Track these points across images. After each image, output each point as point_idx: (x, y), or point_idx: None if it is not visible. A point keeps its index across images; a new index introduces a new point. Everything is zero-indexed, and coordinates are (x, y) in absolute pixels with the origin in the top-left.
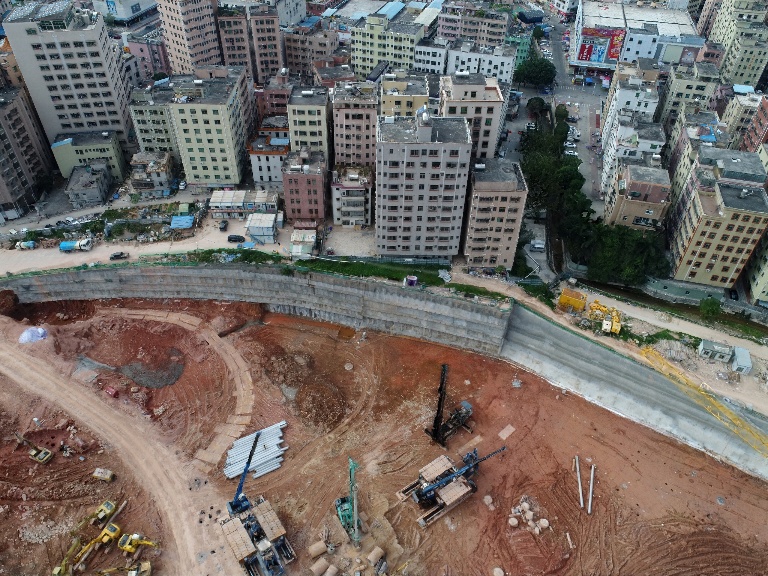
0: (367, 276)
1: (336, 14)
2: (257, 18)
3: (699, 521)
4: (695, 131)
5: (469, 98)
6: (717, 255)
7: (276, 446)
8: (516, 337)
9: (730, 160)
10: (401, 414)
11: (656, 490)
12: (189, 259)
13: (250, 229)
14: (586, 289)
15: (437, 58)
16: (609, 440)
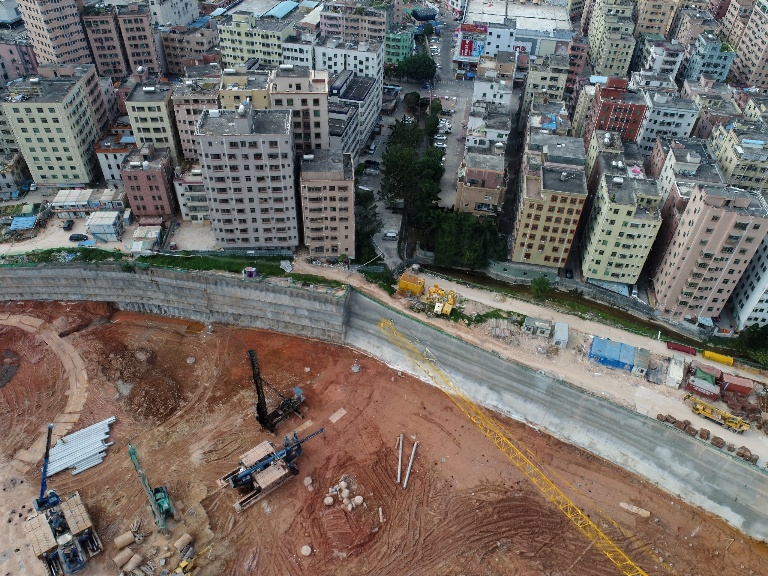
0: (207, 269)
1: (227, 14)
2: (125, 17)
3: (508, 488)
4: (539, 120)
5: (294, 90)
6: (545, 236)
7: (100, 442)
8: (357, 323)
9: (555, 145)
10: (235, 404)
11: (472, 462)
12: (27, 260)
13: (90, 227)
14: (429, 274)
15: (304, 54)
16: (436, 417)
